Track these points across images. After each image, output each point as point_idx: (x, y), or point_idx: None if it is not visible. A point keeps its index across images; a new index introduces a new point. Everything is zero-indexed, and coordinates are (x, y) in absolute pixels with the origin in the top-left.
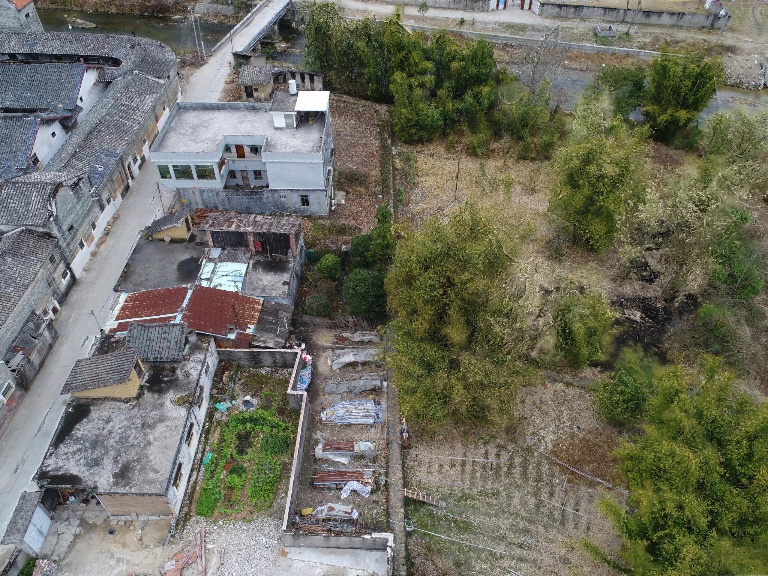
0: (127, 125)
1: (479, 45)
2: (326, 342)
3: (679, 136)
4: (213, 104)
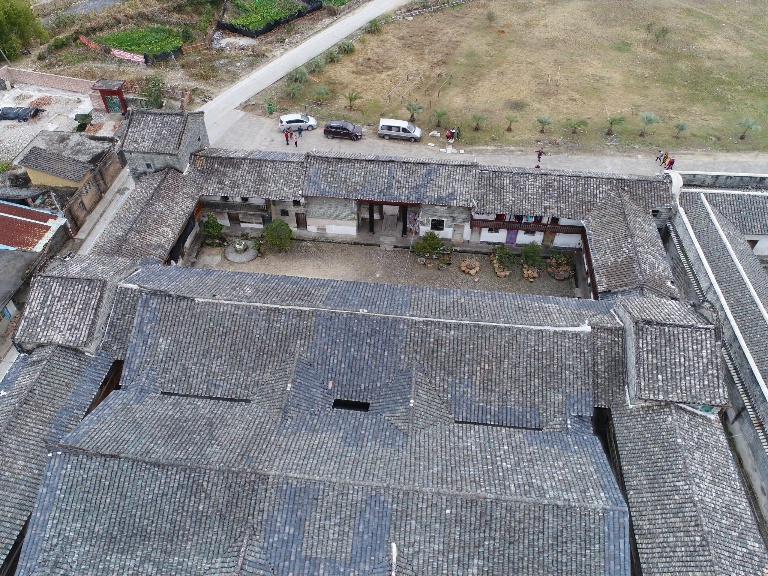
0: None
1: None
2: None
3: None
4: None
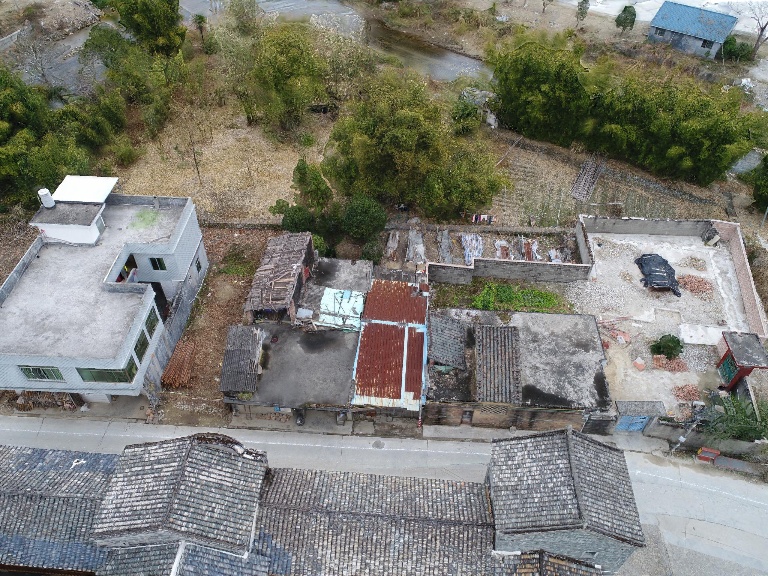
0: None
1: (8, 79)
2: (396, 266)
3: (183, 50)
4: None
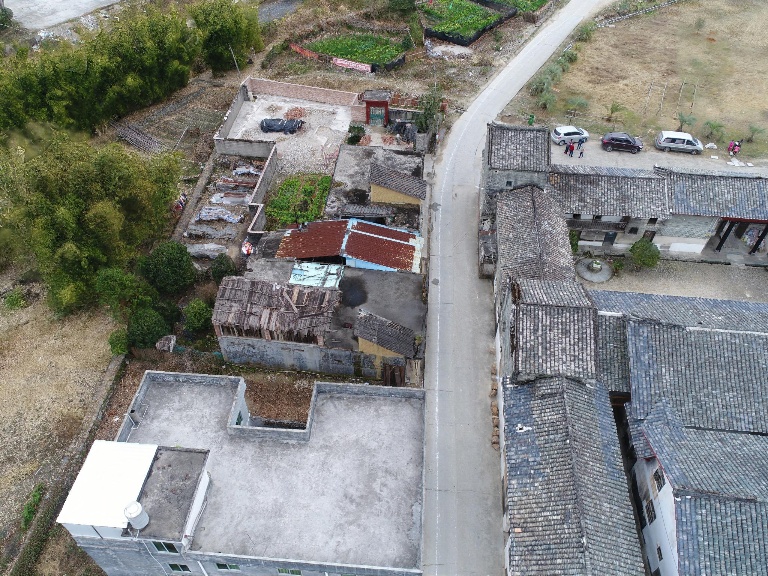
0: (535, 575)
1: None
2: None
3: None
4: (335, 564)
